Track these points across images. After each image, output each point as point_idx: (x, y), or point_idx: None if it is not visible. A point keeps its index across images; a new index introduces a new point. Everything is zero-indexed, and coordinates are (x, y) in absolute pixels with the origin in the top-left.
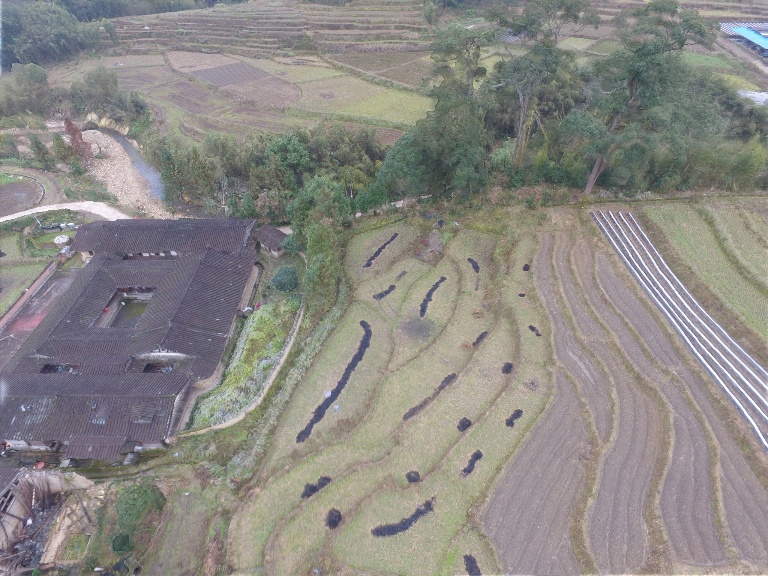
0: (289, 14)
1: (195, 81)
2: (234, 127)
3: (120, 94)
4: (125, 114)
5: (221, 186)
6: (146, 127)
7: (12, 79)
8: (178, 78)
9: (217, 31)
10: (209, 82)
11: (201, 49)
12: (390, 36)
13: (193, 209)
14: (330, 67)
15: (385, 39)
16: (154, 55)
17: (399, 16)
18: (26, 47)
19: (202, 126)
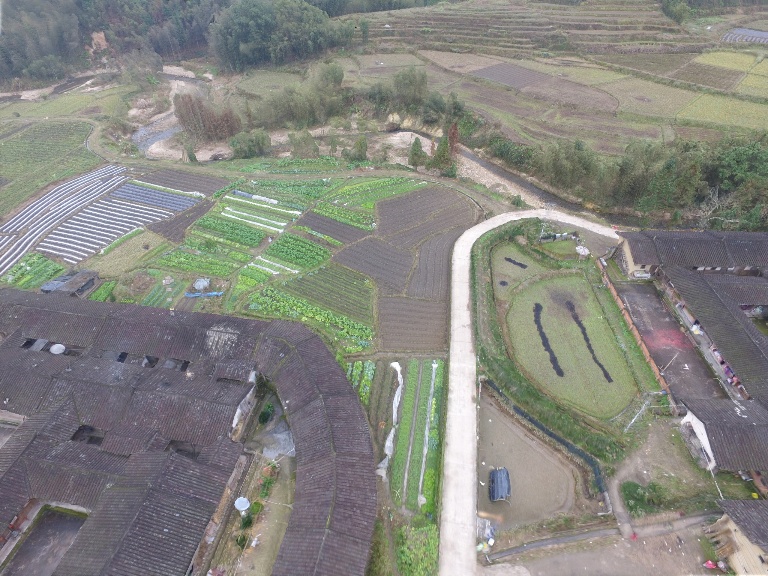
0: (529, 13)
1: (483, 82)
2: (584, 131)
3: (433, 95)
4: (444, 116)
5: (710, 196)
6: (472, 130)
7: (318, 79)
8: (458, 79)
9: (463, 30)
10: (504, 83)
11: (451, 48)
12: (645, 37)
13: (607, 217)
14: (606, 69)
15: (639, 40)
16: (403, 54)
17: (642, 16)
18: (283, 45)
19: (548, 130)
